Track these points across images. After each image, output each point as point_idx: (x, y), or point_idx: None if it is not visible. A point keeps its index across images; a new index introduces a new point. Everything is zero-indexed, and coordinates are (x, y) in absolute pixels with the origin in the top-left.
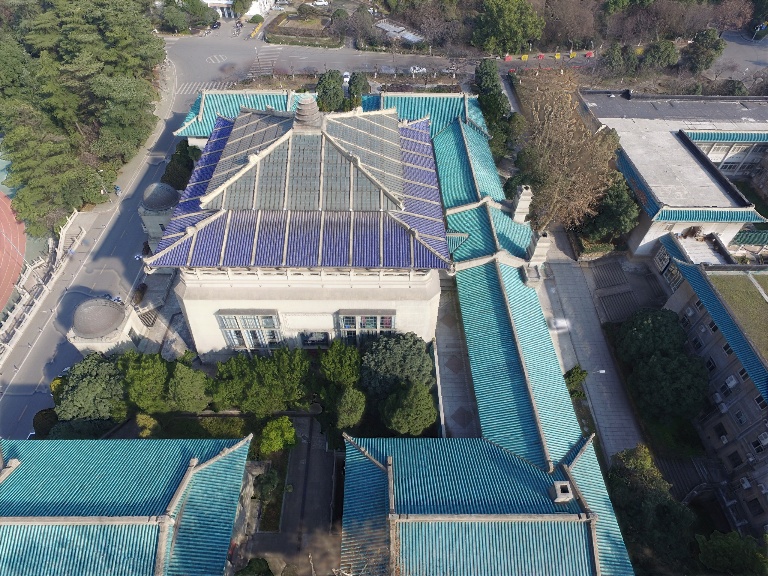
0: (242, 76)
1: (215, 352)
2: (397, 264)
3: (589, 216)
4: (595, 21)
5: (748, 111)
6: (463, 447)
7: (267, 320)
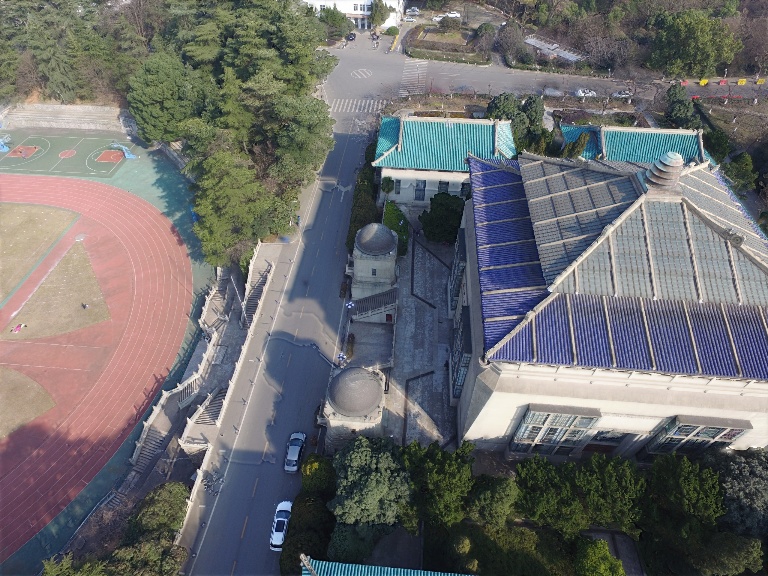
0: (394, 94)
1: (483, 439)
2: None
3: None
4: None
5: None
6: None
7: (583, 420)
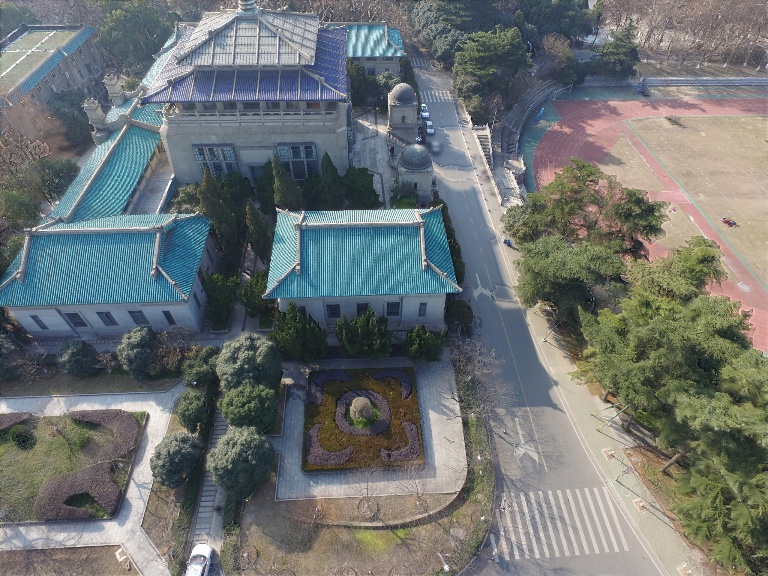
0: None
1: None
2: None
3: None
4: None
5: None
6: None
7: None
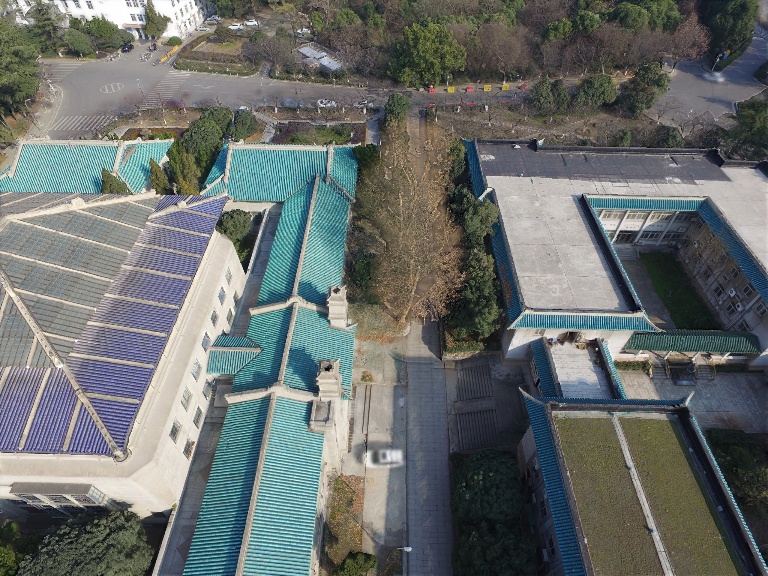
0: (131, 109)
1: None
2: (43, 447)
3: (454, 307)
4: (532, 49)
5: (676, 168)
6: None
7: None
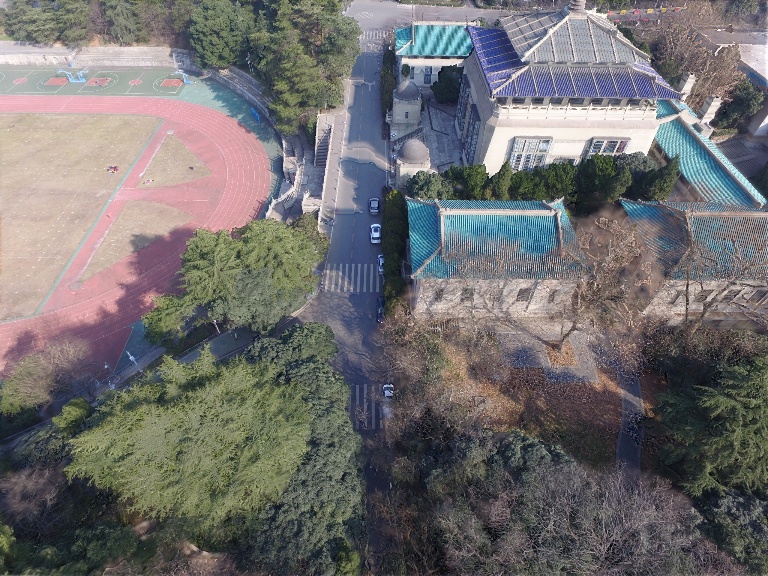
0: None
1: None
2: (647, 96)
3: (719, 108)
4: None
5: None
6: None
7: (544, 144)
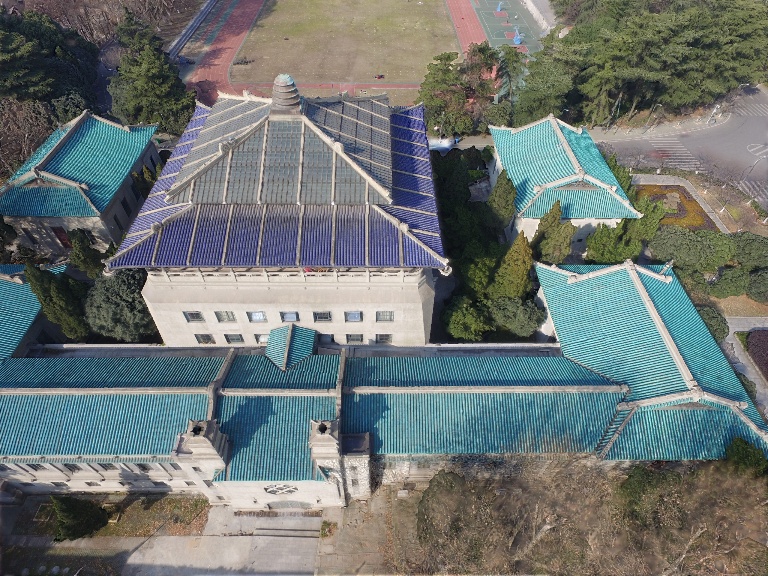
0: None
1: None
2: (133, 226)
3: None
4: None
5: None
6: (6, 337)
7: None
